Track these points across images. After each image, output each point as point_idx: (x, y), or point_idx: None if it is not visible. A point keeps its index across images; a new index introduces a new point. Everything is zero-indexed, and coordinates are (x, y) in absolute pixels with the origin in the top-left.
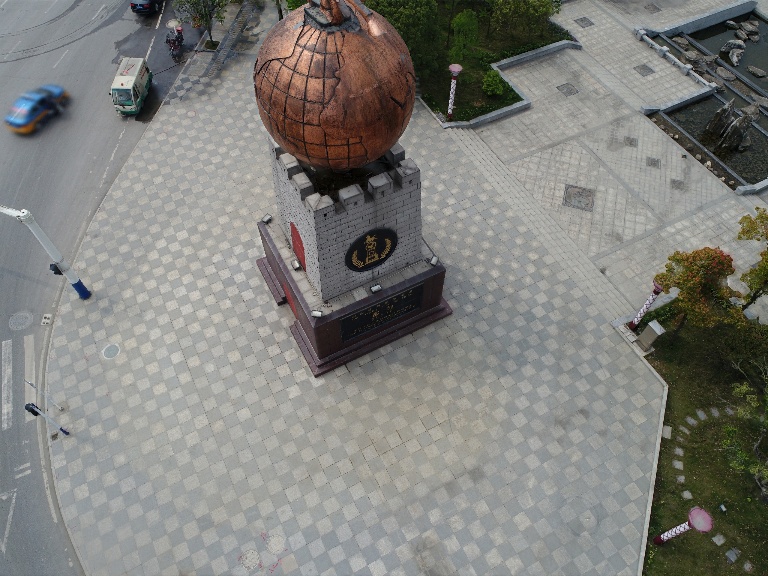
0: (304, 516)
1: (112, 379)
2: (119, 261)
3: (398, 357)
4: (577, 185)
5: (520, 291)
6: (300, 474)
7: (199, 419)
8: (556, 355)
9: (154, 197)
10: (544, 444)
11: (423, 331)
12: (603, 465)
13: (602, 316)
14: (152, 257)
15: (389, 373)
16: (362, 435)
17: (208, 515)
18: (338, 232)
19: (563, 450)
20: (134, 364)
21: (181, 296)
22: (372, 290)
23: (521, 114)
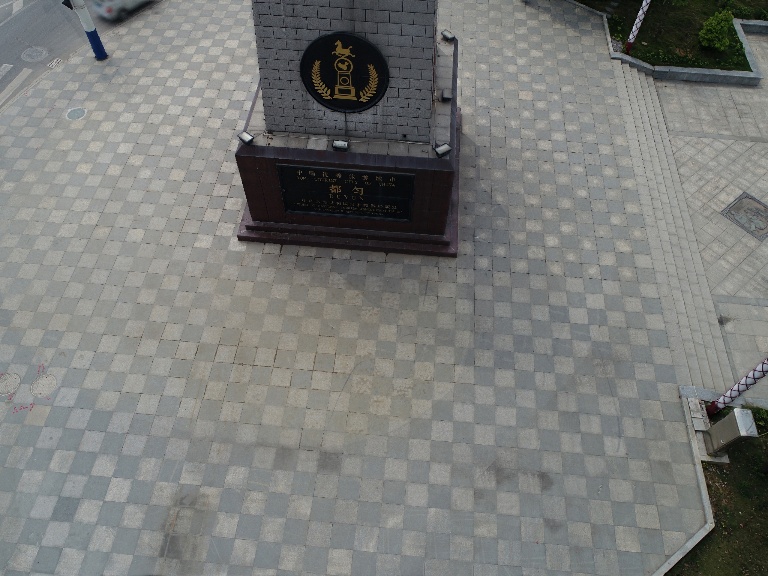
0: (97, 375)
1: (54, 137)
2: (156, 41)
3: (349, 269)
4: (761, 200)
5: (571, 278)
6: (134, 329)
7: (91, 215)
8: (561, 382)
9: (237, 2)
10: (452, 483)
11: (403, 258)
12: (518, 569)
13: (673, 371)
14: (187, 51)
15: (323, 281)
16: (234, 329)
17: (13, 312)
18: (288, 5)
19: (473, 509)
20: (84, 134)
21: (180, 96)
22: (333, 143)
23: (737, 88)
